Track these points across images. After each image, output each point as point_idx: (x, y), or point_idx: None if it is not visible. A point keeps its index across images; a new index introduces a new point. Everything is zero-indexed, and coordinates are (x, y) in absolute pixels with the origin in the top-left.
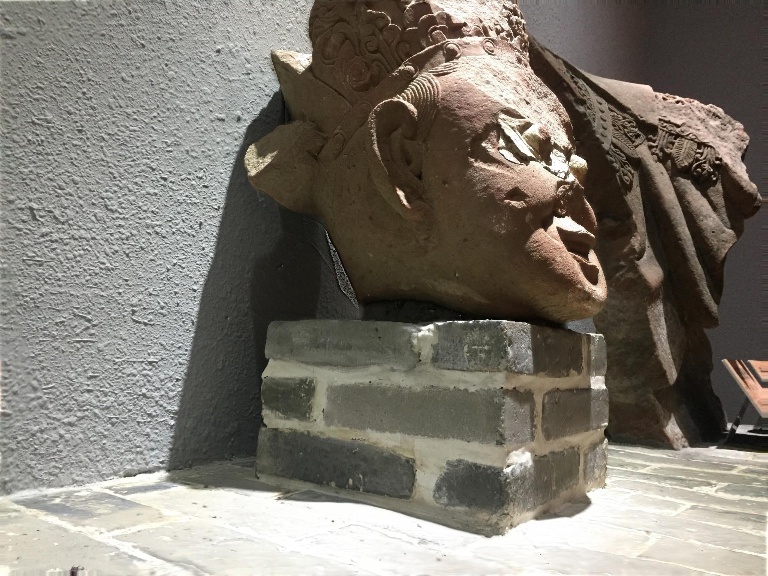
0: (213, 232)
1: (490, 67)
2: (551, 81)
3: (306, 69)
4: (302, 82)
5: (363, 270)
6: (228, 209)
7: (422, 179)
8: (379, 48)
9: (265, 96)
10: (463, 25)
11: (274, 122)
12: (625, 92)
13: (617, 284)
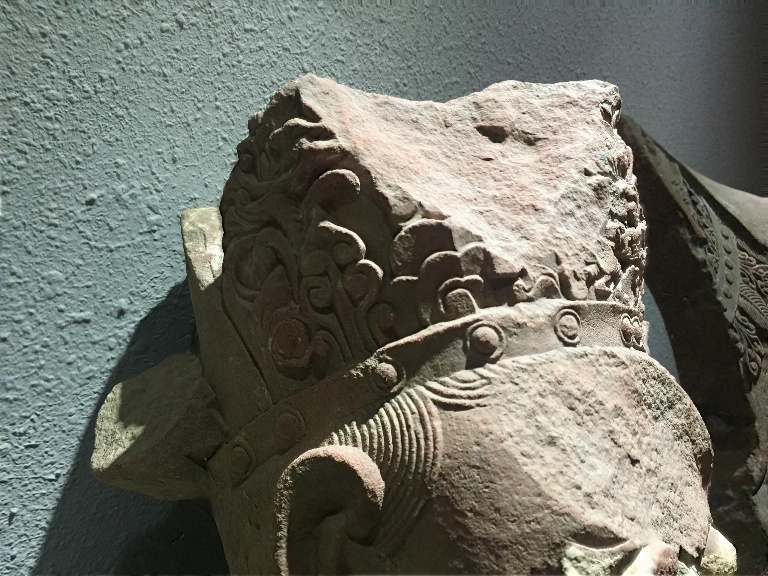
0: (40, 521)
1: (563, 387)
2: (660, 206)
3: (215, 281)
4: (204, 306)
5: None
6: (79, 472)
7: None
8: (334, 304)
9: (183, 263)
10: (518, 275)
11: None
12: (763, 220)
13: (717, 524)
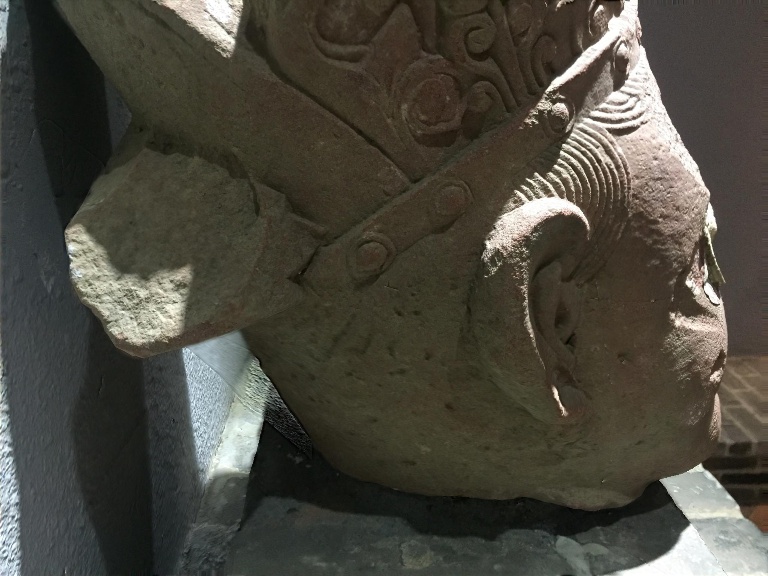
0: (2, 449)
1: None
2: None
3: (238, 39)
4: (235, 80)
5: (389, 457)
6: (11, 367)
7: (573, 346)
8: (494, 47)
9: None
10: None
11: (26, 78)
12: None
13: None
